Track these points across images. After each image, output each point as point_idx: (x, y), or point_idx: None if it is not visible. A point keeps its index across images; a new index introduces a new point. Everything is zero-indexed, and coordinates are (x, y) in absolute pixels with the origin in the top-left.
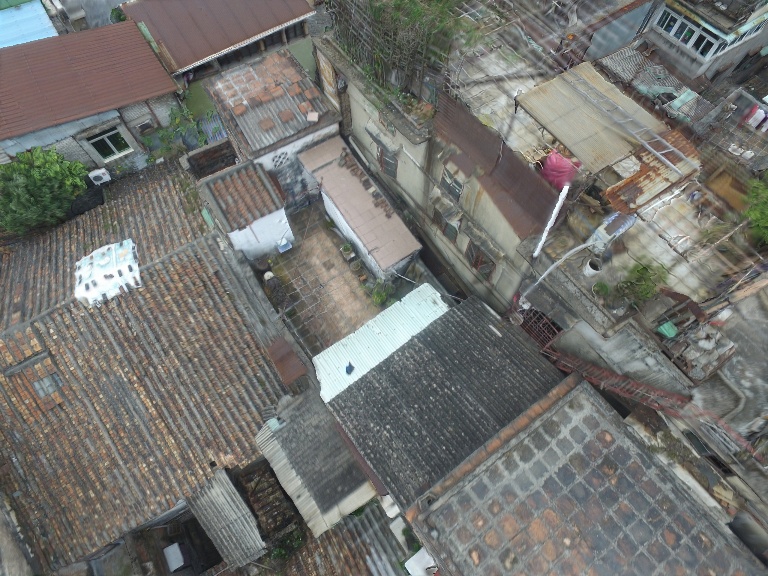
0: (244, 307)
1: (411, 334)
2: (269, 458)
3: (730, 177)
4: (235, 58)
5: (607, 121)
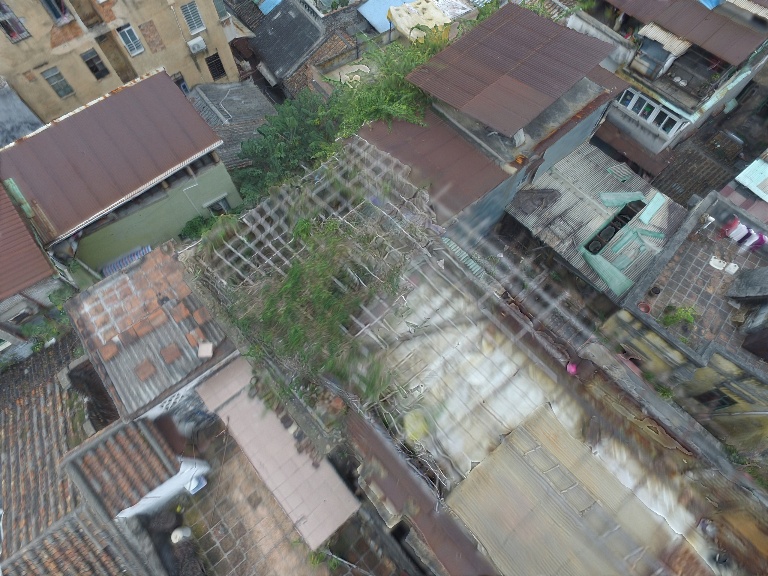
0: None
1: None
2: None
3: (756, 519)
4: (133, 202)
5: (583, 534)
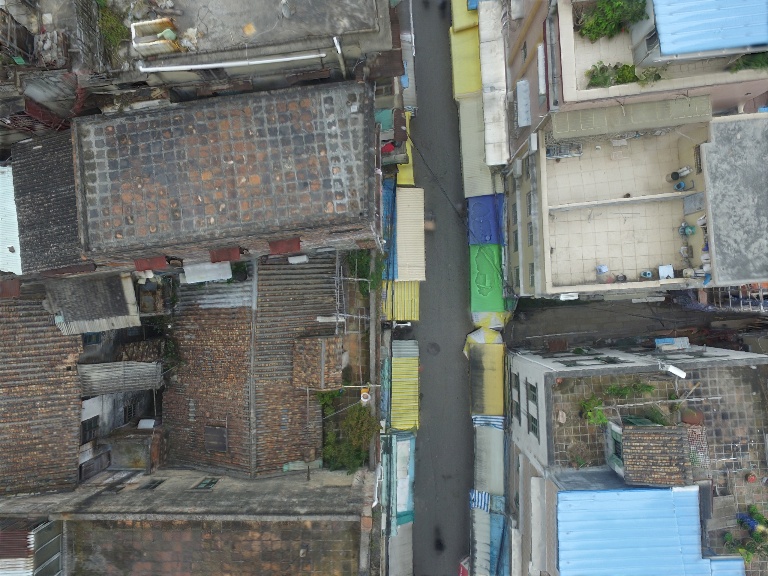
0: None
1: (13, 200)
2: (80, 332)
3: None
4: None
5: None
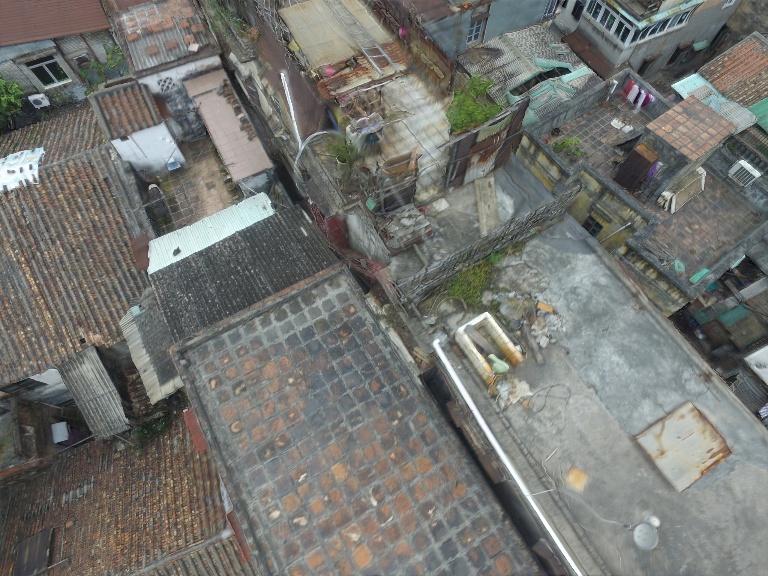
0: (126, 211)
1: (236, 230)
2: (127, 338)
3: None
4: None
5: (343, 32)
